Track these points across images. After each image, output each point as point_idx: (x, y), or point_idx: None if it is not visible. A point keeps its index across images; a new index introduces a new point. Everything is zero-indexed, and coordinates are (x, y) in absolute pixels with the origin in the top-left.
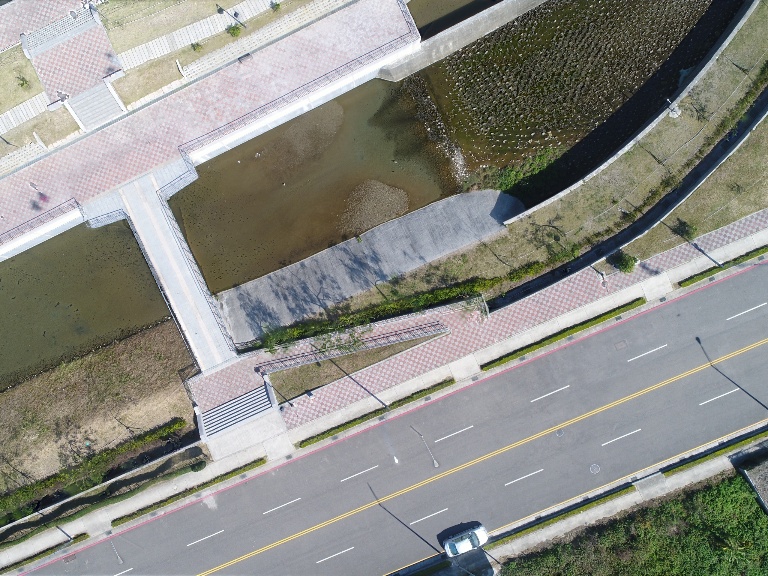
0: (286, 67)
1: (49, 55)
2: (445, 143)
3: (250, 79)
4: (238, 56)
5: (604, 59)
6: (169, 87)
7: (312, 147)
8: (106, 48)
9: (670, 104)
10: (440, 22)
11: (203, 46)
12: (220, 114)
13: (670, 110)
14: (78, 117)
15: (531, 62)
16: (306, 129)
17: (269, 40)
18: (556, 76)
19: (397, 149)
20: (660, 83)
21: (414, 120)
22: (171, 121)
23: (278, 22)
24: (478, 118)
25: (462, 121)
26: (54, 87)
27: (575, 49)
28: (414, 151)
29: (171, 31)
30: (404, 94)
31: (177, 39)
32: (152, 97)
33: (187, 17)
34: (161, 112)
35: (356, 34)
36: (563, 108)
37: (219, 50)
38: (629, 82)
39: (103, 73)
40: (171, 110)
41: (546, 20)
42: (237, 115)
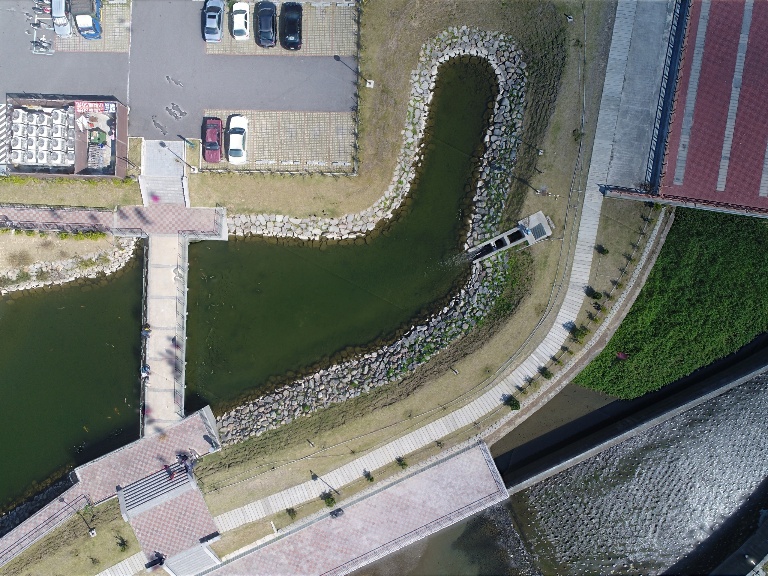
0: (377, 522)
1: (146, 516)
2: (528, 570)
3: (342, 533)
4: (330, 511)
5: (685, 497)
6: (263, 541)
7: (397, 571)
8: (202, 511)
9: (754, 566)
10: (522, 450)
11: (298, 511)
12: (313, 566)
13: (754, 572)
14: (175, 573)
15: (613, 496)
16: (391, 553)
17: (360, 496)
18: (637, 510)
19: (480, 572)
20: (740, 522)
21: (497, 546)
22: (265, 572)
23: (371, 488)
24: (560, 547)
25: (545, 549)
26: (152, 547)
27: (656, 486)
28: (497, 575)
29: (266, 496)
30: (487, 521)
31: (272, 504)
32: (246, 550)
33: (282, 483)
34: (255, 563)
35: (446, 492)
36: (644, 542)
37: (313, 514)
38: (710, 520)
39: (200, 535)
40: (264, 561)
41: (627, 457)
42: (329, 567)
